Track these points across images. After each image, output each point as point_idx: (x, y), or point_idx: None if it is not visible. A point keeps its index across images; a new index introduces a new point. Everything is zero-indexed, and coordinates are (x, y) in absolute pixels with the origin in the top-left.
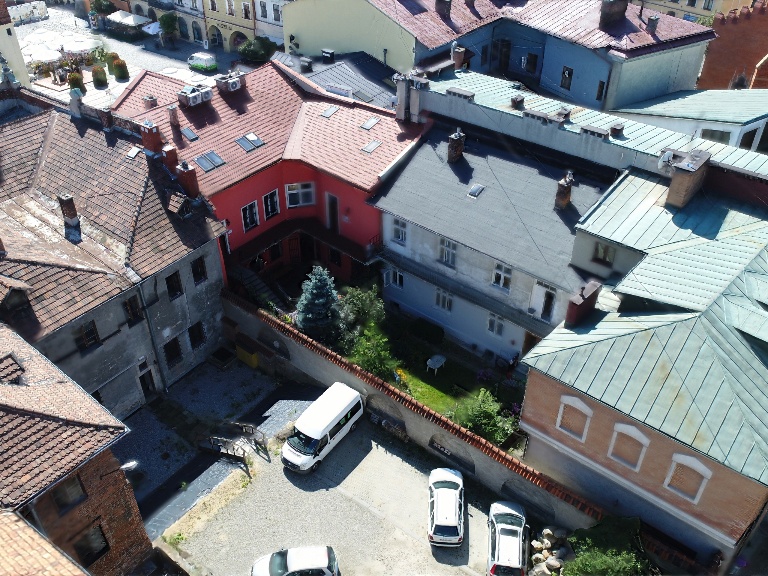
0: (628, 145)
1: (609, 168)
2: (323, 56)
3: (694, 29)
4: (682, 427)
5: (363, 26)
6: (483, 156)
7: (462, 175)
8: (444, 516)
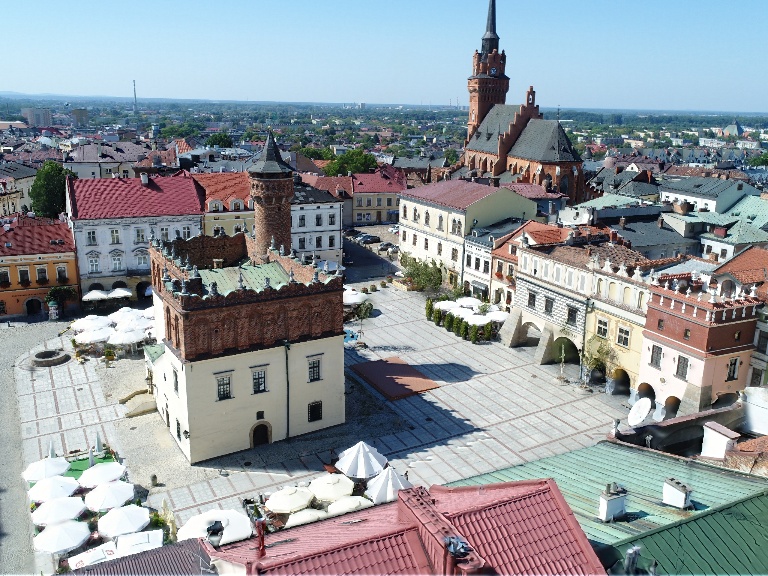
0: None
1: None
2: (513, 220)
3: None
4: (765, 239)
5: (513, 205)
6: (627, 224)
7: (632, 231)
8: None
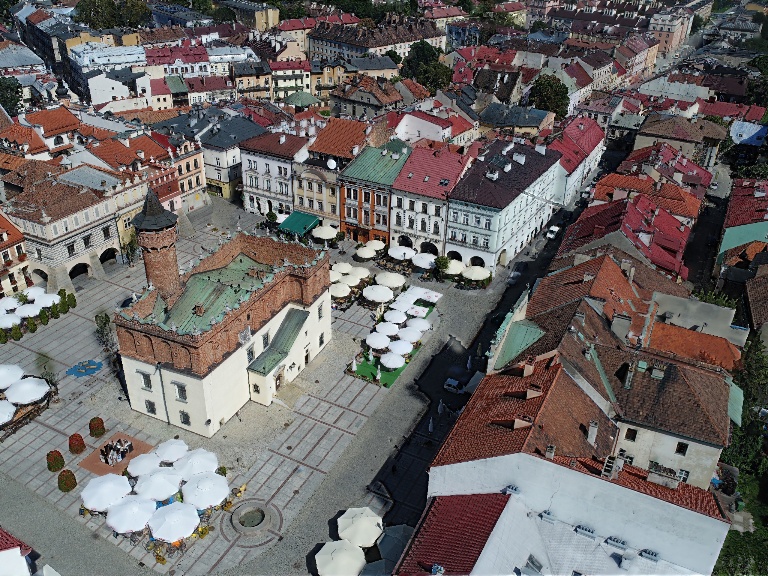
0: None
1: None
2: None
3: None
4: None
5: None
6: None
7: None
8: None
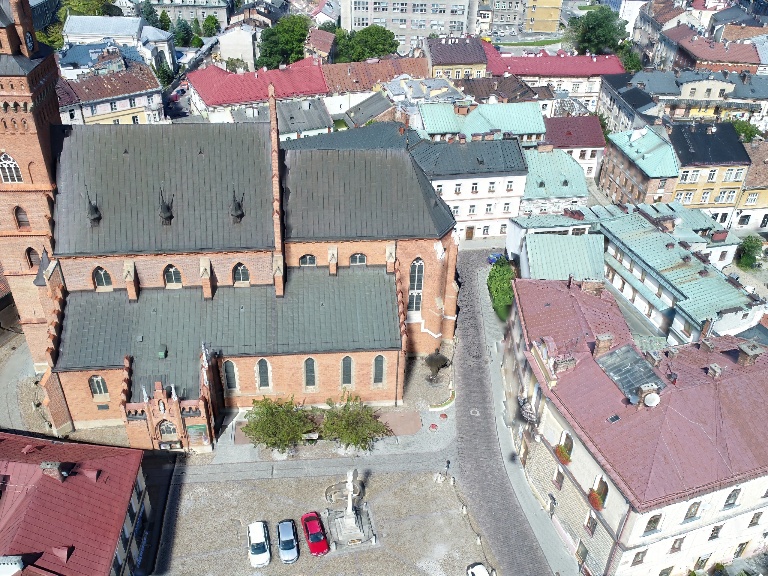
0: (672, 241)
1: None
2: None
3: (533, 280)
4: None
5: None
6: None
7: None
8: (751, 287)
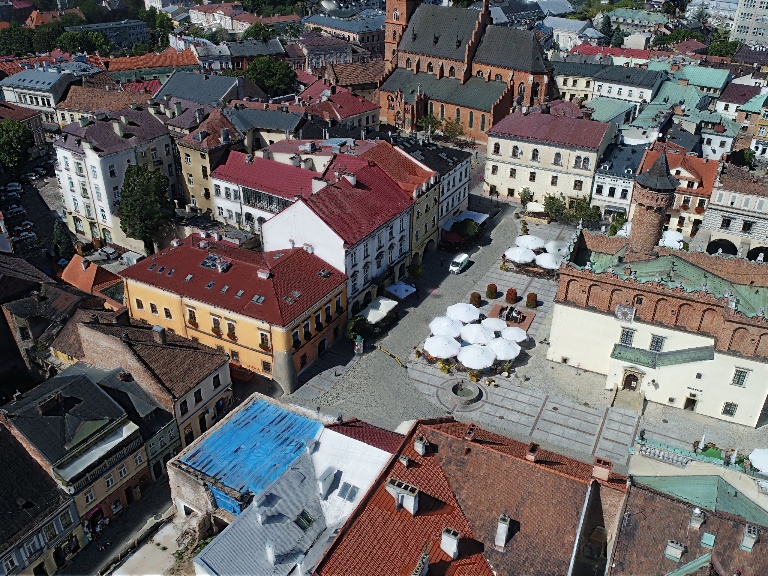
0: None
1: (669, 119)
2: None
3: None
4: None
5: None
6: None
7: None
8: None
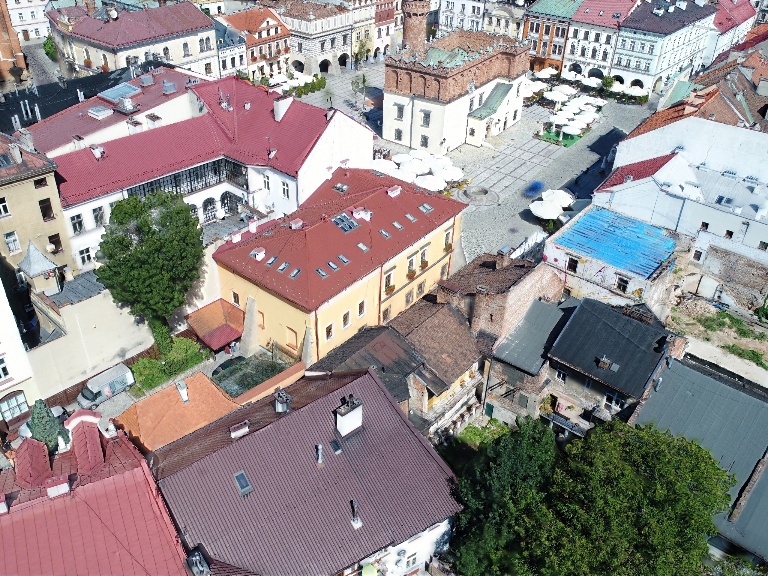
0: None
1: None
2: None
3: None
4: None
5: None
6: None
7: None
8: None
